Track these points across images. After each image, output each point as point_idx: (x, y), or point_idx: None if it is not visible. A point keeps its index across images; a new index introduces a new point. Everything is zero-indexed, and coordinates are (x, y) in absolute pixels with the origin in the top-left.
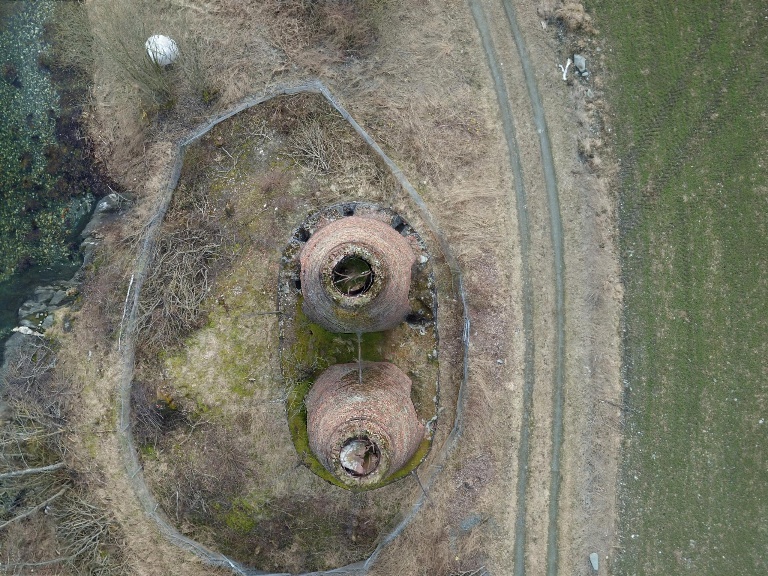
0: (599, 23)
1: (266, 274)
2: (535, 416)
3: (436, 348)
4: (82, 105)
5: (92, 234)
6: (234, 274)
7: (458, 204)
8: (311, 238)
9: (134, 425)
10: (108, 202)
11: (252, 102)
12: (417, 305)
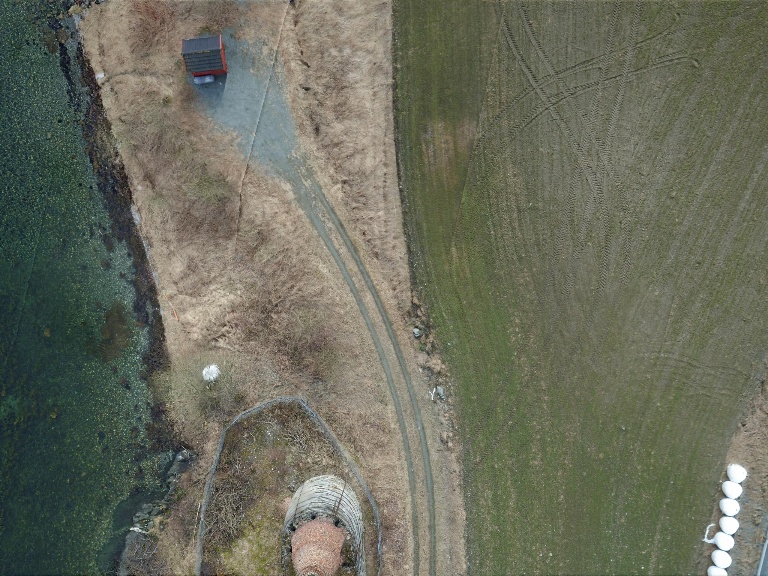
0: (450, 370)
1: (274, 508)
2: None
3: None
4: (166, 400)
5: (174, 474)
6: (257, 508)
7: (376, 470)
8: (296, 532)
9: None
10: (183, 456)
11: (263, 402)
12: (346, 559)
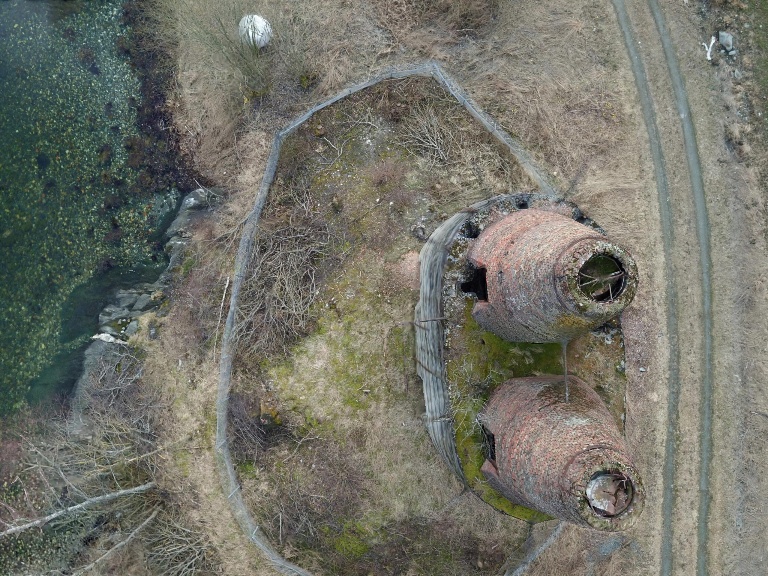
0: None
1: (382, 275)
2: (681, 429)
3: (624, 359)
4: (166, 92)
5: (179, 233)
6: (345, 275)
7: (594, 197)
8: (484, 234)
9: (232, 441)
10: (195, 198)
11: (354, 87)
12: None
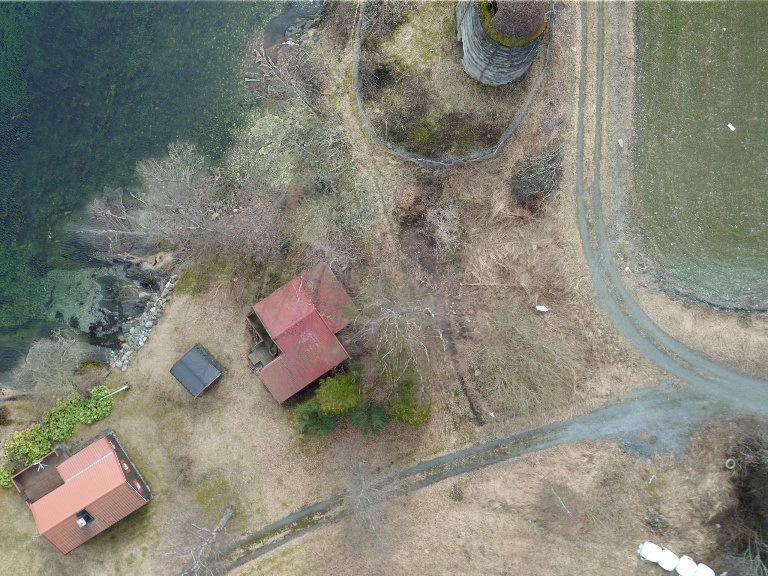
0: None
1: None
2: (588, 65)
3: None
4: None
5: None
6: None
7: None
8: None
9: (361, 86)
10: None
11: None
12: None
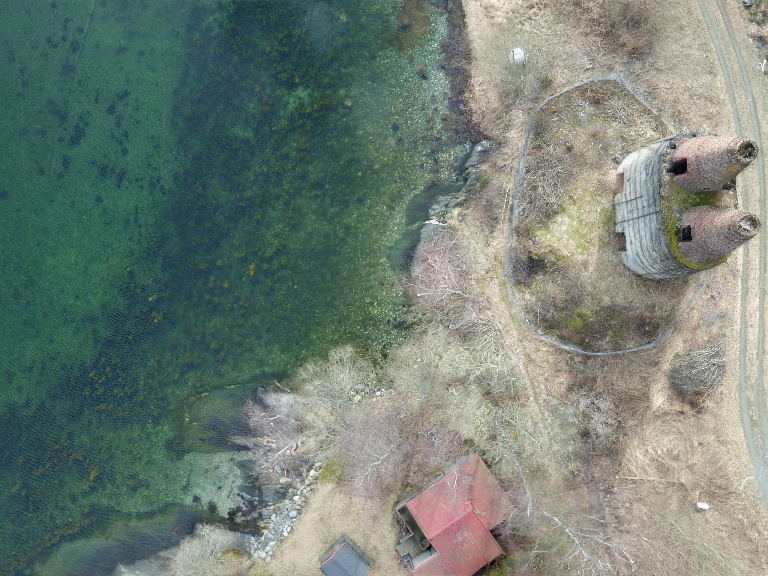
0: None
1: (597, 182)
2: (750, 258)
3: None
4: (465, 89)
5: (473, 165)
6: (577, 182)
7: None
8: (679, 147)
9: (511, 272)
10: (482, 146)
11: (571, 86)
12: None
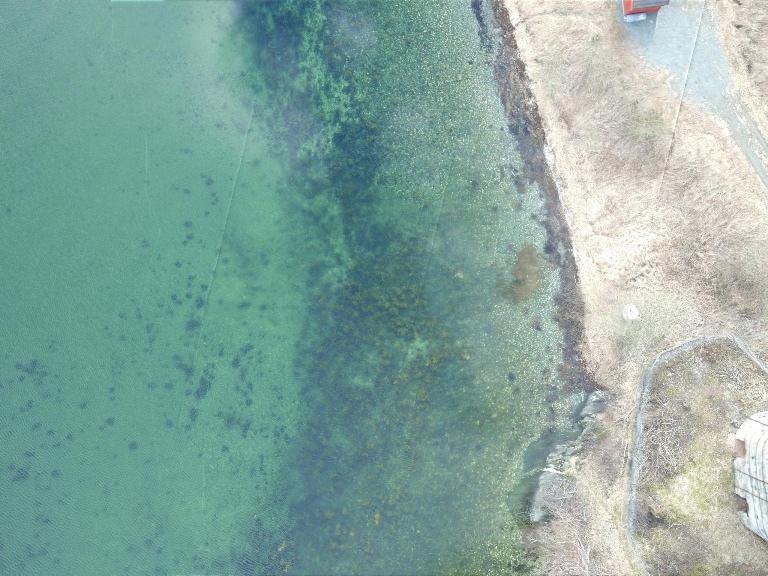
0: None
1: (716, 444)
2: None
3: None
4: (579, 341)
5: (589, 415)
6: (696, 444)
7: None
8: None
9: (631, 525)
10: (597, 396)
11: (684, 341)
12: None
